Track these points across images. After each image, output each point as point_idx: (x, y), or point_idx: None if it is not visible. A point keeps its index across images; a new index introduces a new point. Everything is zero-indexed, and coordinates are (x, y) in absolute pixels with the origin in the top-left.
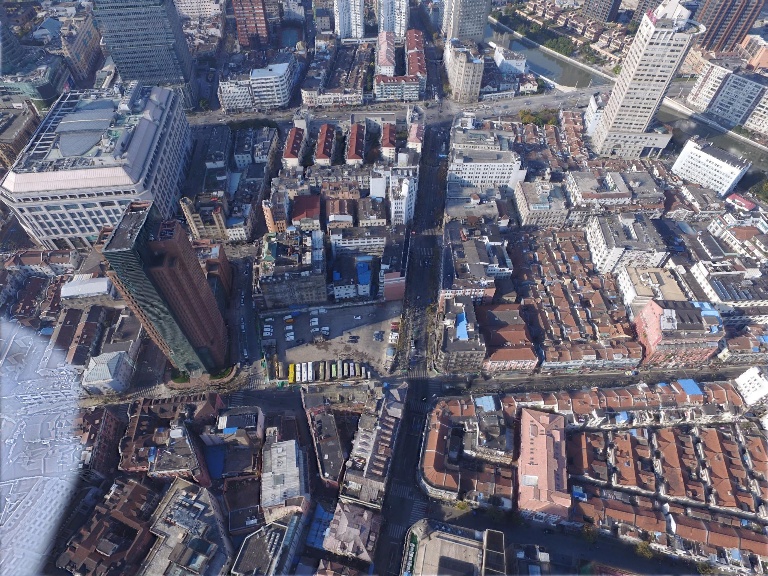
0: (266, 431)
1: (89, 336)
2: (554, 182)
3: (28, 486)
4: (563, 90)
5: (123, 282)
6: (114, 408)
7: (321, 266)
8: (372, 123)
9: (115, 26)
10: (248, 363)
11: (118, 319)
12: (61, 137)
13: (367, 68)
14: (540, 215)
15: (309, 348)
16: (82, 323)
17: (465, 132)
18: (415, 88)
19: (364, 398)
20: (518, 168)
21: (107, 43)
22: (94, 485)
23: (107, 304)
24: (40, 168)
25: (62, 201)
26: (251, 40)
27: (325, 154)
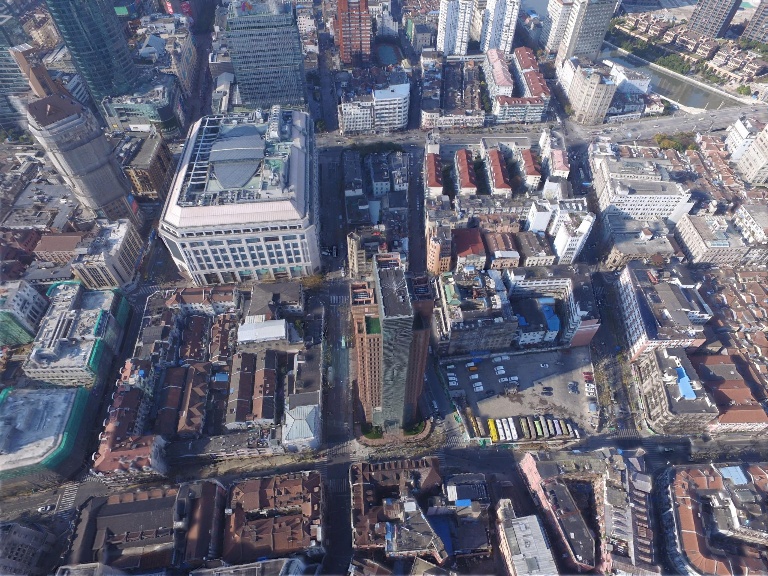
0: (500, 503)
1: (271, 385)
2: (718, 215)
3: (273, 570)
4: (690, 111)
5: (384, 347)
6: (309, 467)
7: (510, 311)
8: (503, 147)
9: (245, 47)
10: (440, 417)
11: (293, 365)
12: (215, 166)
13: (479, 87)
14: (718, 253)
15: (501, 400)
16: (261, 370)
17: (618, 160)
18: (539, 110)
19: (602, 467)
20: (686, 201)
21: (234, 64)
22: (316, 560)
23: (280, 348)
24: (204, 201)
25: (227, 236)
26: (354, 57)
27: (472, 183)
